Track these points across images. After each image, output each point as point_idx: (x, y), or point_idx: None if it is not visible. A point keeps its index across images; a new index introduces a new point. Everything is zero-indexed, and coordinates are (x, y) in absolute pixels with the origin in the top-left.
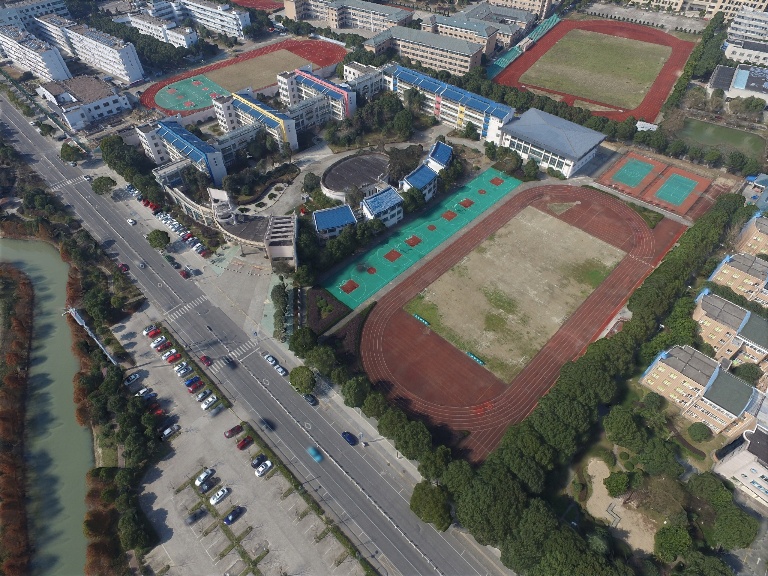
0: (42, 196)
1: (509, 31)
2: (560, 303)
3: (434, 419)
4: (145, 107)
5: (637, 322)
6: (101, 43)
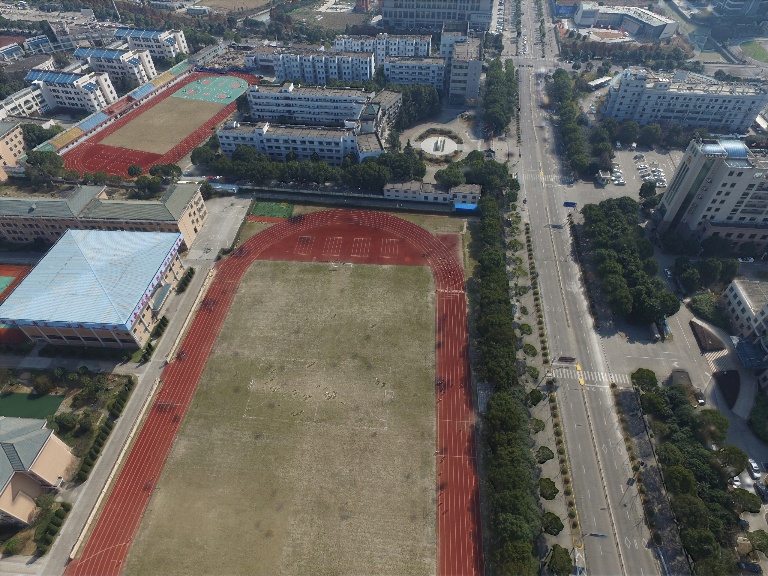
0: (211, 23)
1: None
2: None
3: None
4: (240, 73)
5: None
6: (304, 50)
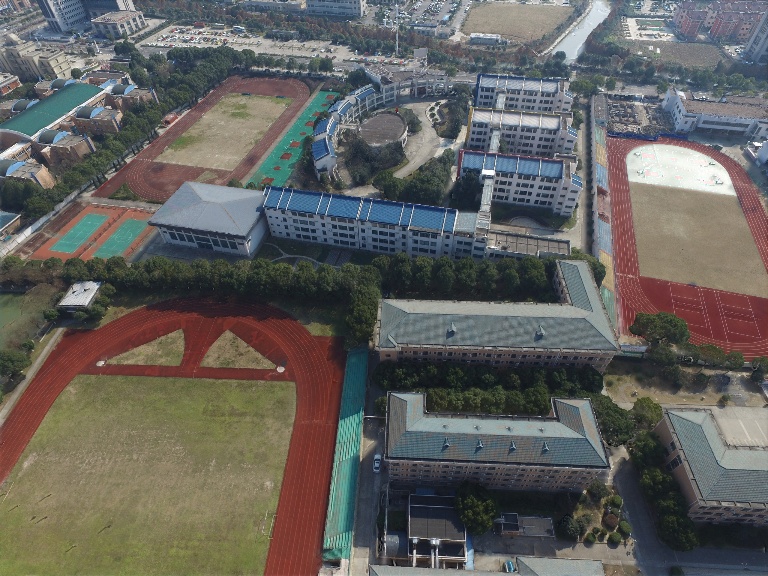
0: (549, 61)
1: (384, 572)
2: (204, 123)
3: None
4: (673, 139)
5: (160, 104)
6: None
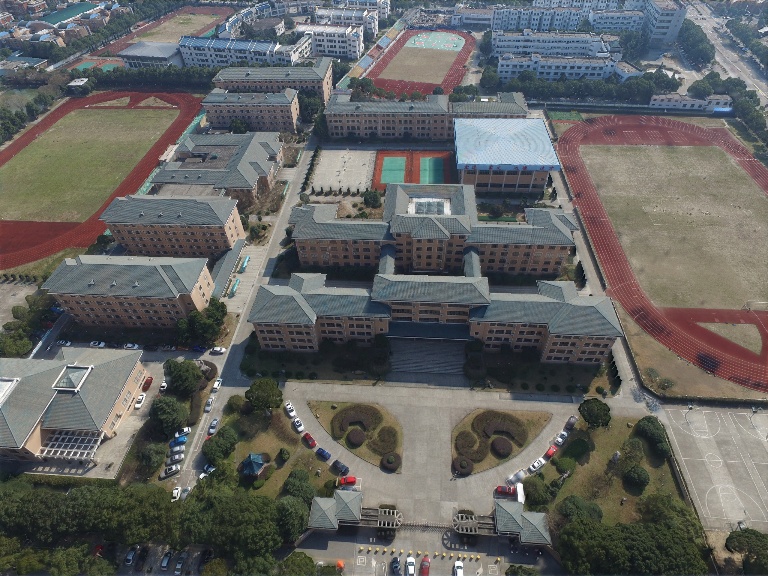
0: None
1: None
2: None
3: (204, 6)
4: (447, 29)
5: (134, 14)
6: None
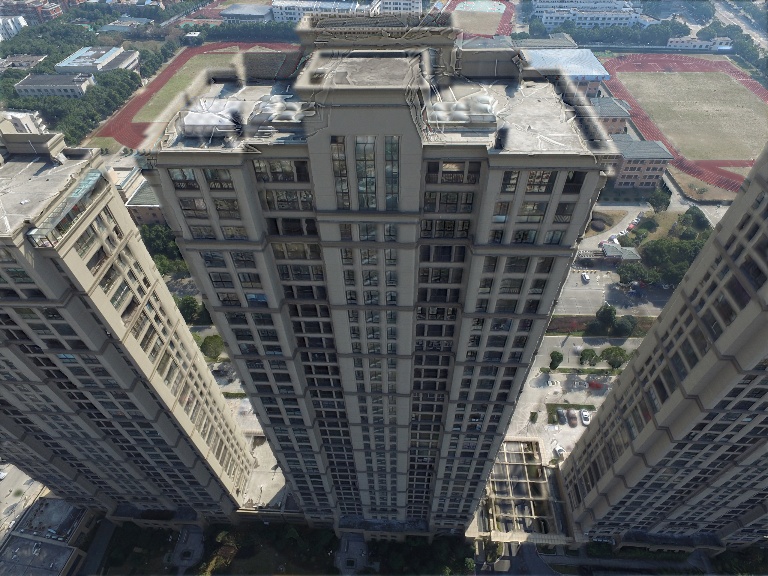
0: None
1: None
2: None
3: None
4: None
5: None
6: None
